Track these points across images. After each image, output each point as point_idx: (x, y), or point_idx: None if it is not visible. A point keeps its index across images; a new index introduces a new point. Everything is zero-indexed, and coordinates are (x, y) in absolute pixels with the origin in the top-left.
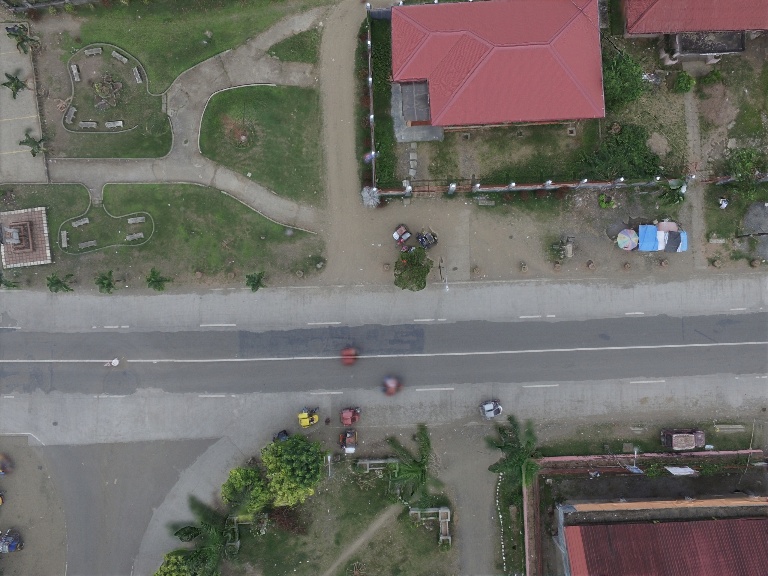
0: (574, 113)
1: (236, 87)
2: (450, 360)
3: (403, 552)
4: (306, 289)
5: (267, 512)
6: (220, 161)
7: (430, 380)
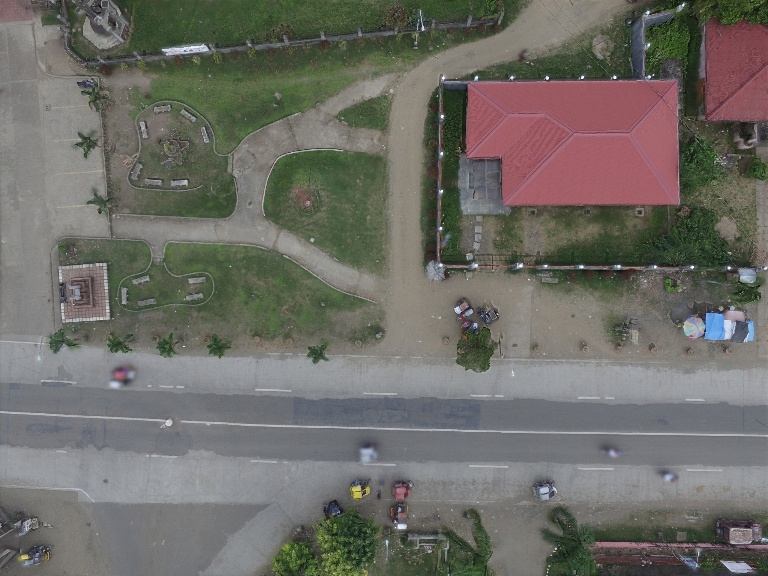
0: (648, 200)
1: (303, 151)
2: (505, 438)
3: None
4: (363, 358)
5: None
6: (283, 225)
7: (484, 457)
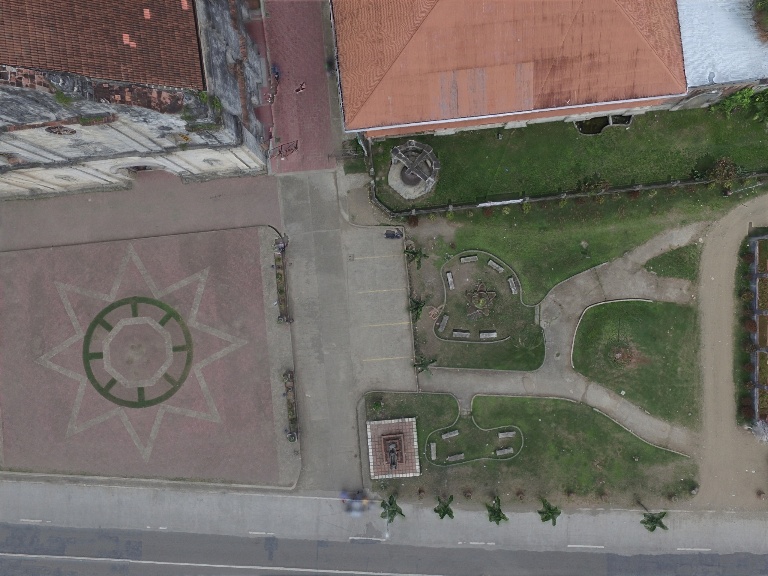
0: None
1: (612, 301)
2: None
3: None
4: (676, 513)
5: None
6: (593, 377)
7: None
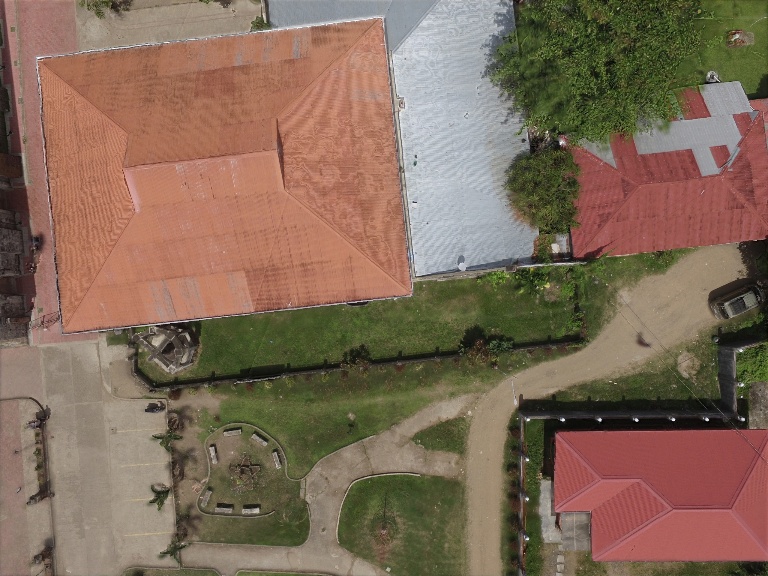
0: (744, 557)
1: (378, 475)
2: None
3: None
4: None
5: None
6: (358, 553)
7: None
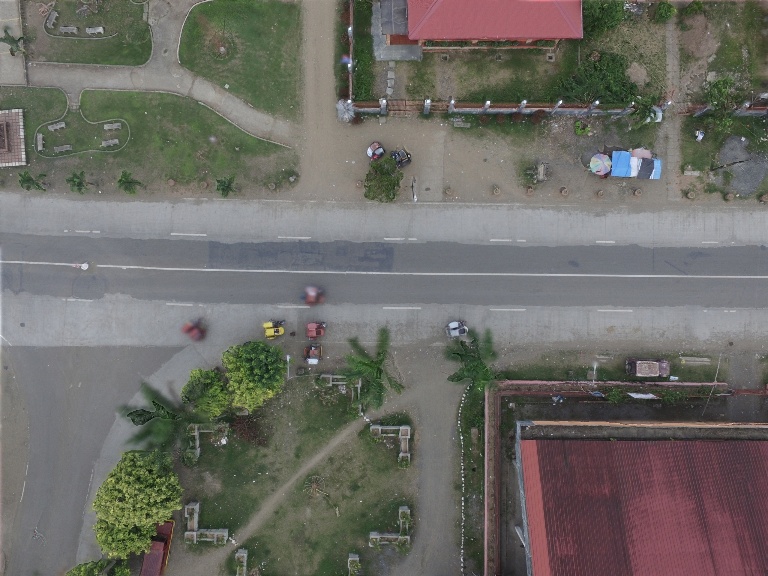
0: (551, 32)
1: None
2: (418, 280)
3: (363, 468)
4: (278, 203)
5: (229, 422)
6: (198, 72)
7: (397, 299)
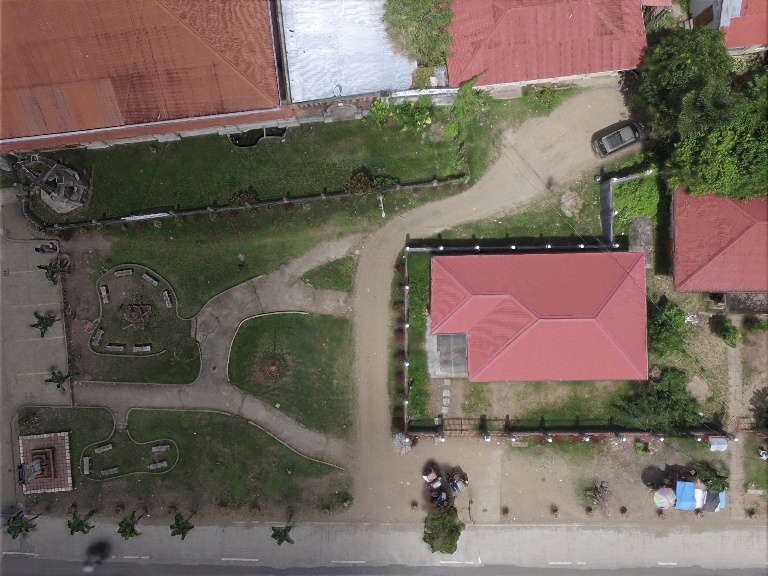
0: (616, 375)
1: (268, 314)
2: None
3: None
4: (331, 525)
5: None
6: (248, 390)
7: None
